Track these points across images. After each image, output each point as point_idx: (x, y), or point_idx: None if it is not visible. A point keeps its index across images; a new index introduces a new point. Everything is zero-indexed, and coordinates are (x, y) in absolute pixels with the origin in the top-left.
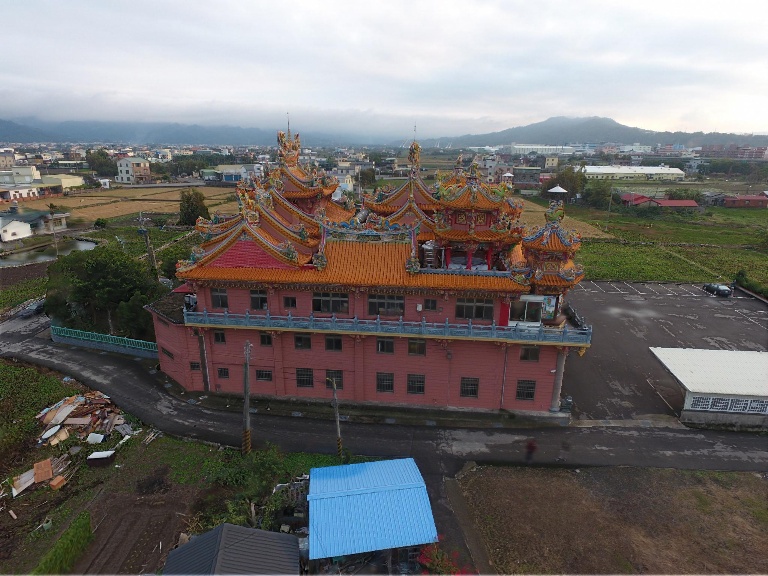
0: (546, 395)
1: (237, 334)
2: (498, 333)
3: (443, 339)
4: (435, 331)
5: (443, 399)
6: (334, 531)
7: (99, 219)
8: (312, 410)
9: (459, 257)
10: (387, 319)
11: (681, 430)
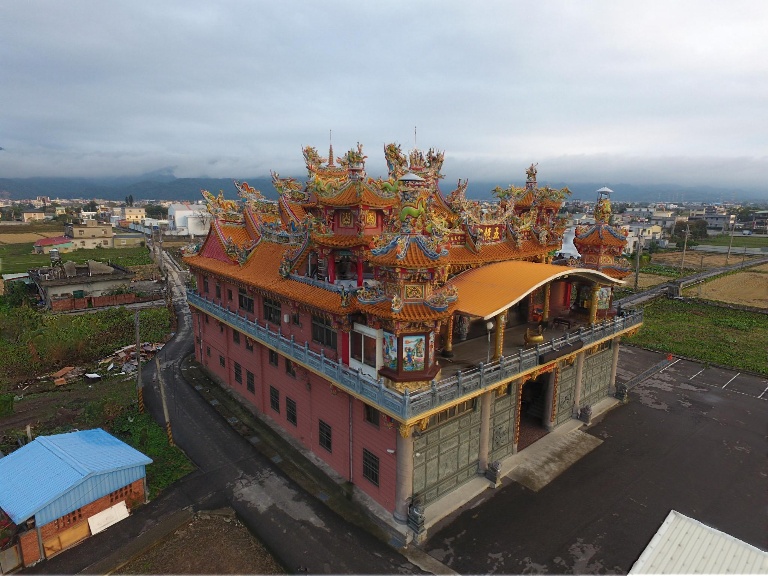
0: (390, 487)
1: (212, 318)
2: (325, 367)
3: (290, 360)
4: (285, 348)
5: (309, 440)
6: (6, 467)
7: None
8: (227, 404)
9: (368, 273)
10: (264, 325)
11: None
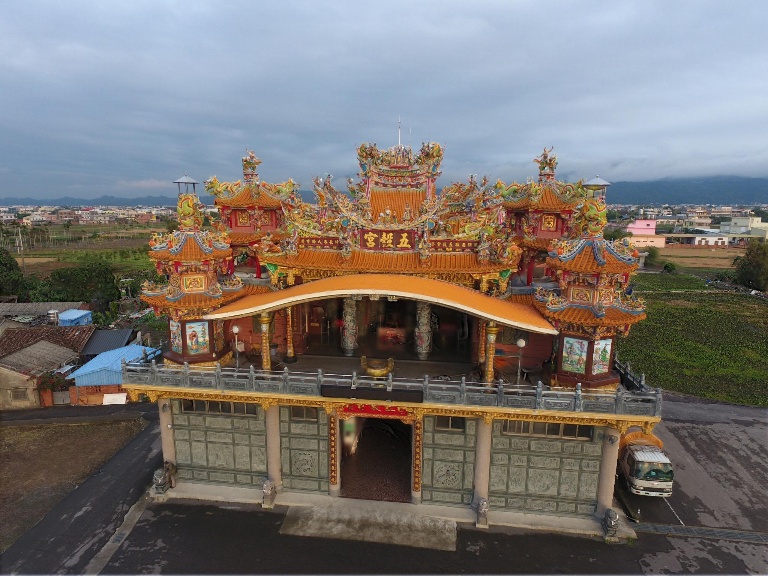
0: None
1: None
2: None
3: None
4: None
5: None
6: None
7: (669, 263)
8: None
9: None
10: None
11: None
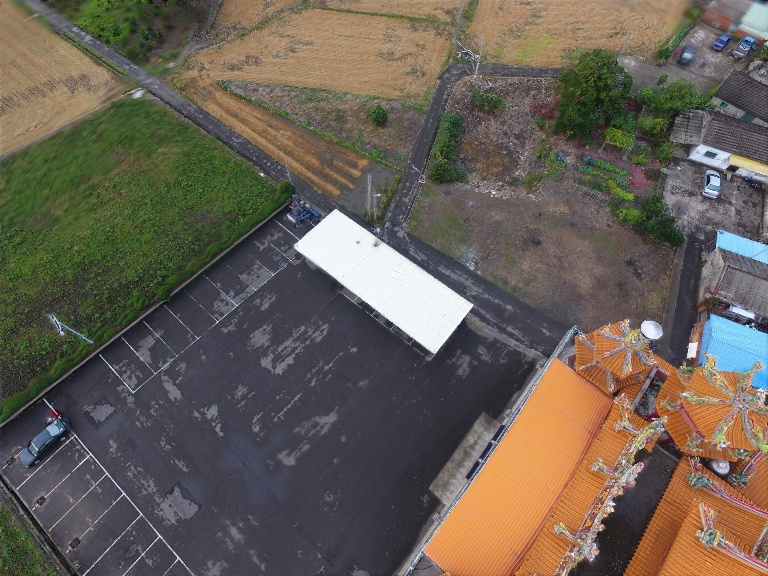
0: None
1: None
2: None
3: None
4: None
5: None
6: (764, 341)
7: None
8: None
9: None
10: None
11: (475, 314)
